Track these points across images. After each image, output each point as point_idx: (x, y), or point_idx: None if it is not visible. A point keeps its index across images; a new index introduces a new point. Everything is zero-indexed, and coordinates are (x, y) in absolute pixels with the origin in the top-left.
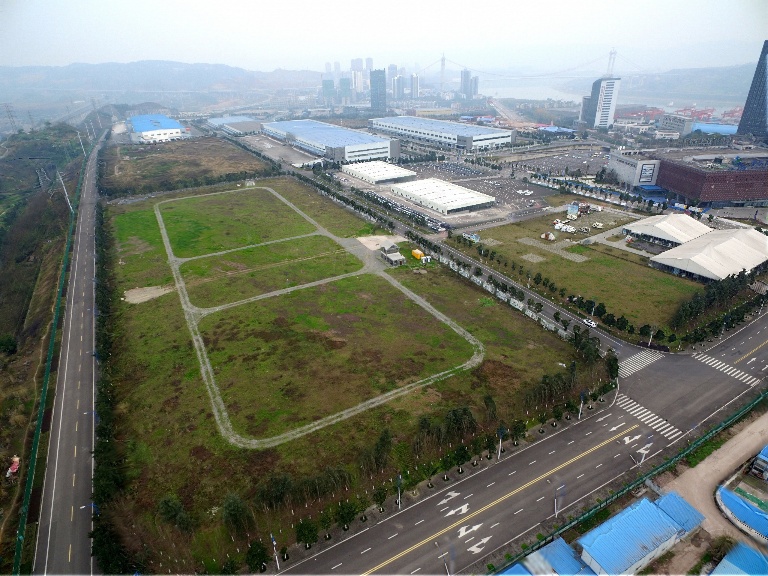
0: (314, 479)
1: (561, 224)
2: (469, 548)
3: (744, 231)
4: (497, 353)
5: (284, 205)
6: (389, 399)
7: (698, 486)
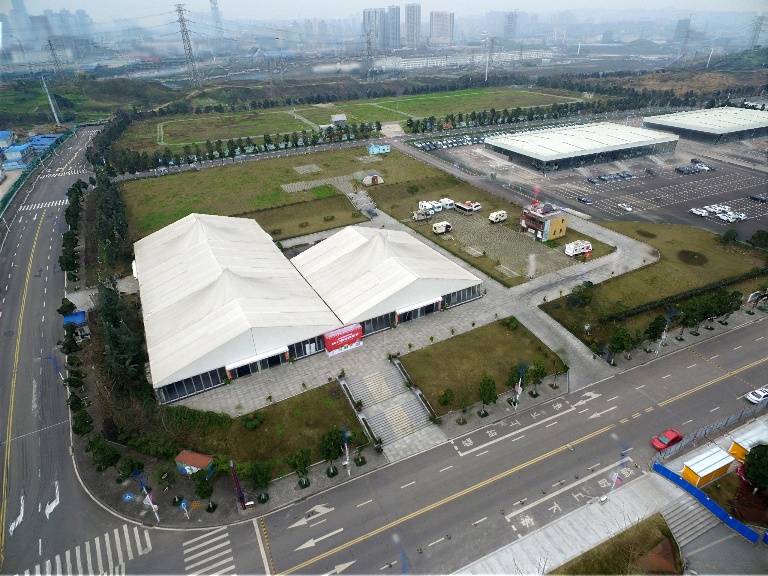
0: (118, 118)
1: (444, 199)
2: (72, 147)
3: (243, 302)
4: (161, 146)
5: None
6: (158, 133)
7: (14, 173)
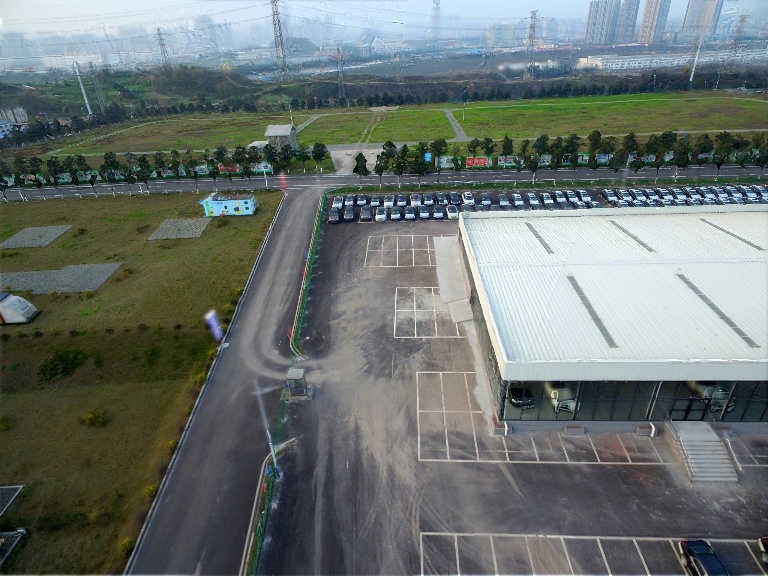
0: (96, 113)
1: None
2: None
3: None
4: None
5: (674, 129)
6: None
7: None
